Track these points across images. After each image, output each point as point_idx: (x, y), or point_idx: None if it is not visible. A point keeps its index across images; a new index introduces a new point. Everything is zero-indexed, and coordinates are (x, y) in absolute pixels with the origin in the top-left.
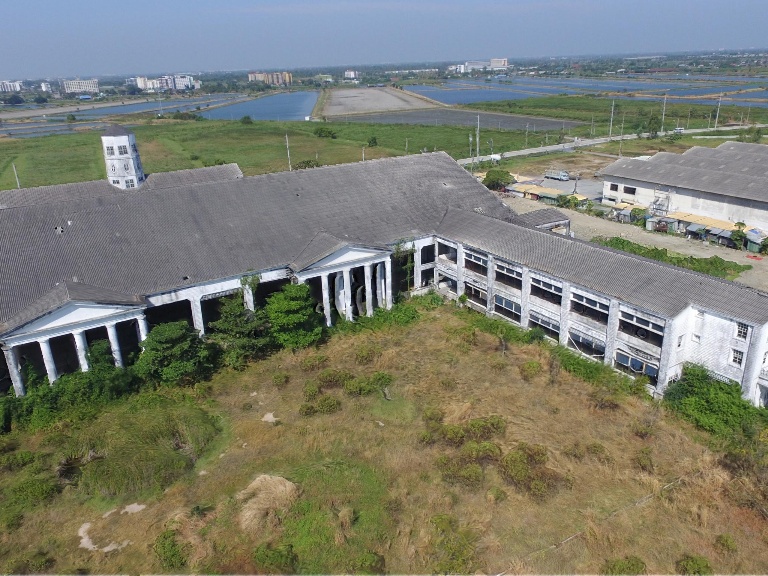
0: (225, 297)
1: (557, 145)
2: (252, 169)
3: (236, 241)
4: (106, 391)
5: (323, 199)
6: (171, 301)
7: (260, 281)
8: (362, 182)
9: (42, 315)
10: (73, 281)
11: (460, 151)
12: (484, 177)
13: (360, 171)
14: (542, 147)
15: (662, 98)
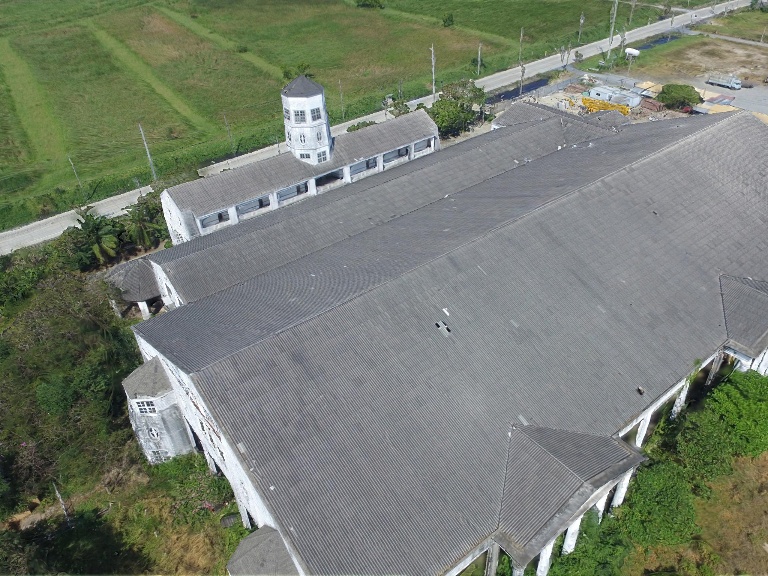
0: (668, 400)
1: (664, 21)
2: (337, 71)
3: (647, 310)
4: (606, 575)
5: (685, 216)
6: (631, 427)
7: (698, 370)
8: (704, 178)
9: (568, 519)
10: (525, 425)
11: (566, 36)
12: (654, 90)
13: (689, 158)
14: (650, 25)
15: None
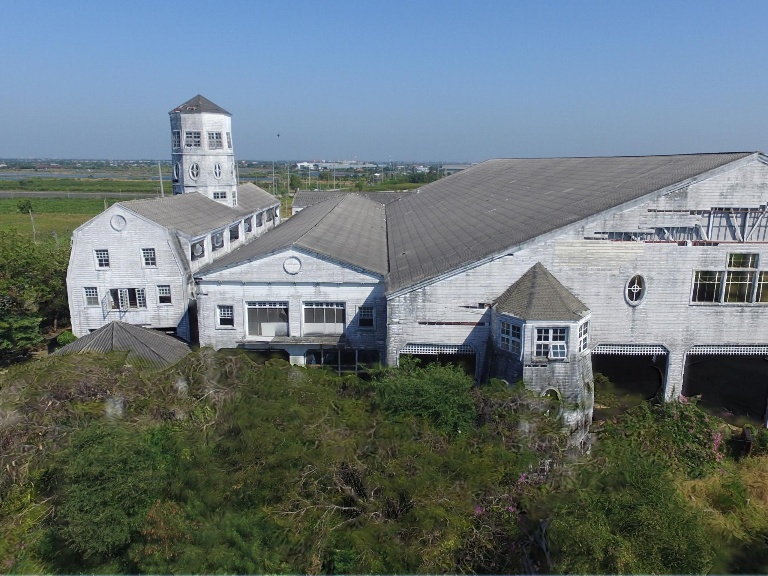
0: None
1: None
2: None
3: None
4: None
5: None
6: None
7: None
8: None
9: None
10: None
11: None
12: None
13: None
14: None
15: (286, 163)
